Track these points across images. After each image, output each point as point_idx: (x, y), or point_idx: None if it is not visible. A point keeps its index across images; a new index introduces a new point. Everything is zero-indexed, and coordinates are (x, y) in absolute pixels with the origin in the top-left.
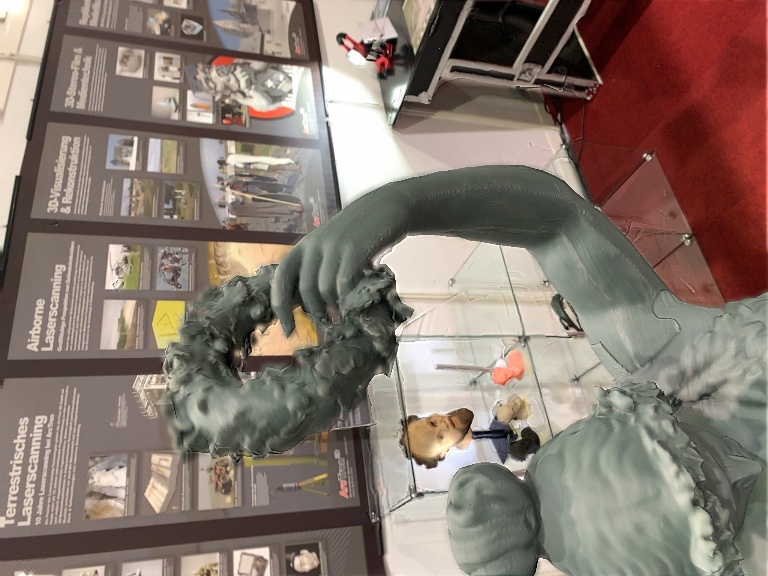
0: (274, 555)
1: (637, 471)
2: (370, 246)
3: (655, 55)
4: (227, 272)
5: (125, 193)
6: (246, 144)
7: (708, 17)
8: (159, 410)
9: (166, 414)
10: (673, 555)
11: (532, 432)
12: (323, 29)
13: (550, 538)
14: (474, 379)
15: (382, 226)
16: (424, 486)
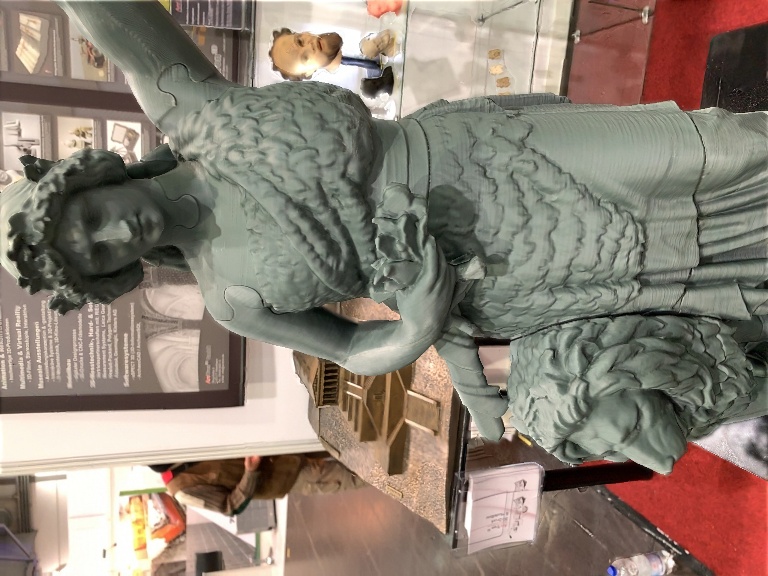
0: (145, 131)
1: (9, 227)
2: None
3: None
4: None
5: None
6: None
7: None
8: None
9: None
10: None
11: (391, 73)
12: None
13: None
14: None
15: None
16: None
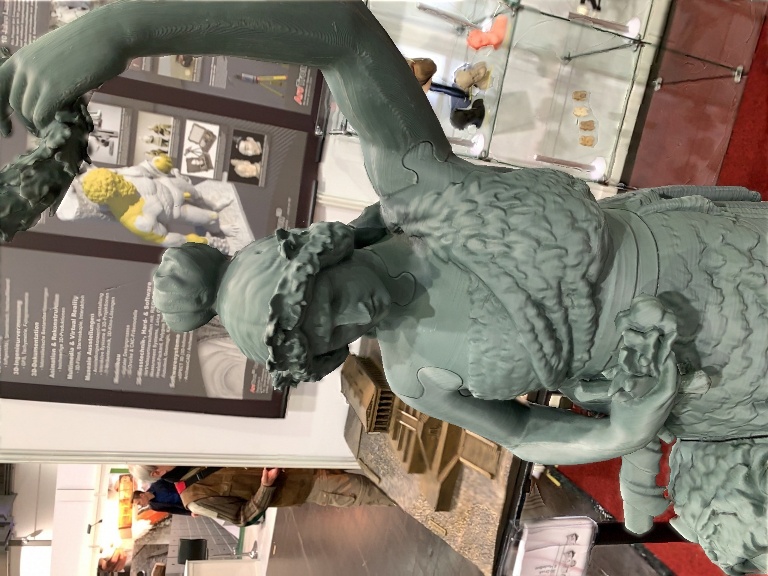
0: (223, 134)
1: (260, 305)
2: (65, 91)
3: None
4: None
5: None
6: None
7: None
8: None
9: None
10: (265, 356)
11: (482, 106)
12: None
13: (218, 310)
14: (463, 25)
15: (82, 71)
16: None
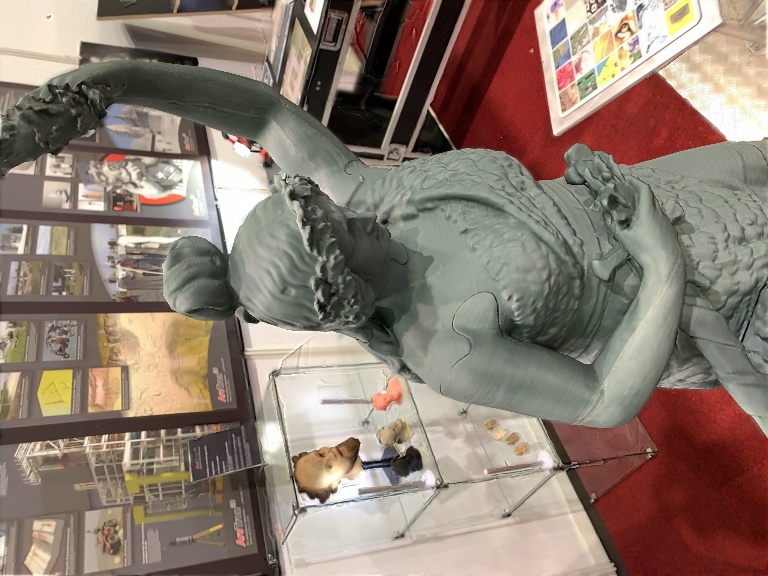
0: None
1: (273, 204)
2: (84, 77)
3: (497, 129)
4: (117, 340)
5: (12, 274)
6: (137, 227)
7: (530, 94)
8: (43, 476)
9: (50, 479)
10: (294, 247)
11: (414, 449)
12: (212, 130)
13: (233, 276)
14: (366, 419)
15: (96, 69)
16: (324, 528)
